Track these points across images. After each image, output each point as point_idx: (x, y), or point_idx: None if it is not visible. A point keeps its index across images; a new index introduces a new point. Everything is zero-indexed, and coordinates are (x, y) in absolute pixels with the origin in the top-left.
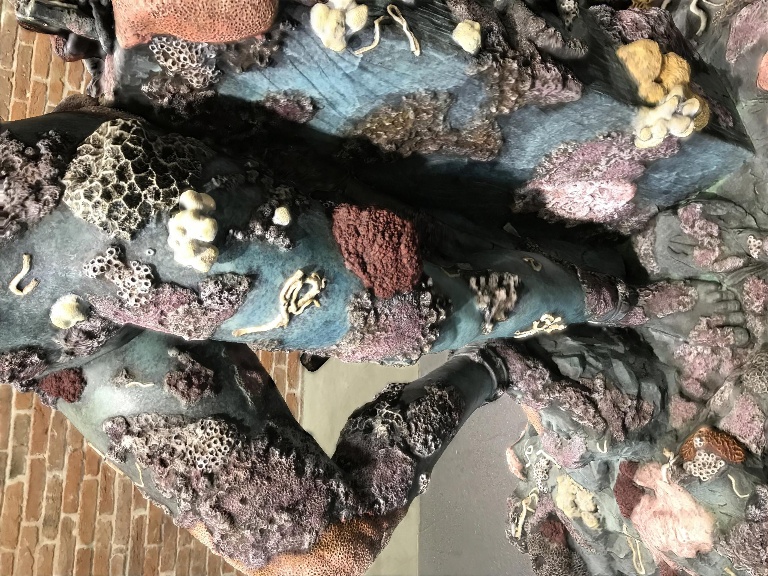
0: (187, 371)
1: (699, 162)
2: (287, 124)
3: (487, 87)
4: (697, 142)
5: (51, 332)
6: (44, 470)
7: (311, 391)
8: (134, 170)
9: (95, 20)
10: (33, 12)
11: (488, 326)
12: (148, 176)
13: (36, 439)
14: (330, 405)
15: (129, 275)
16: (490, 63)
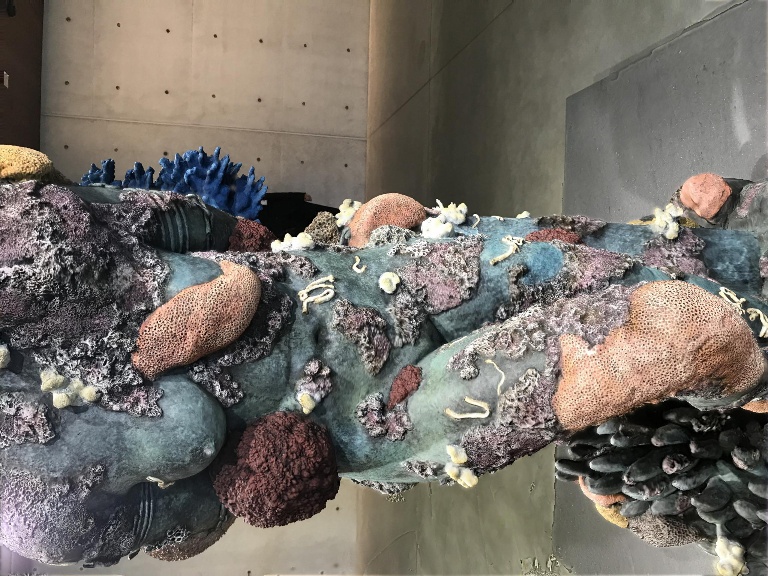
0: None
1: (730, 248)
2: None
3: (551, 227)
4: (707, 233)
5: (383, 304)
6: None
7: None
8: None
9: None
10: None
11: (672, 274)
12: None
13: None
14: None
15: None
16: None
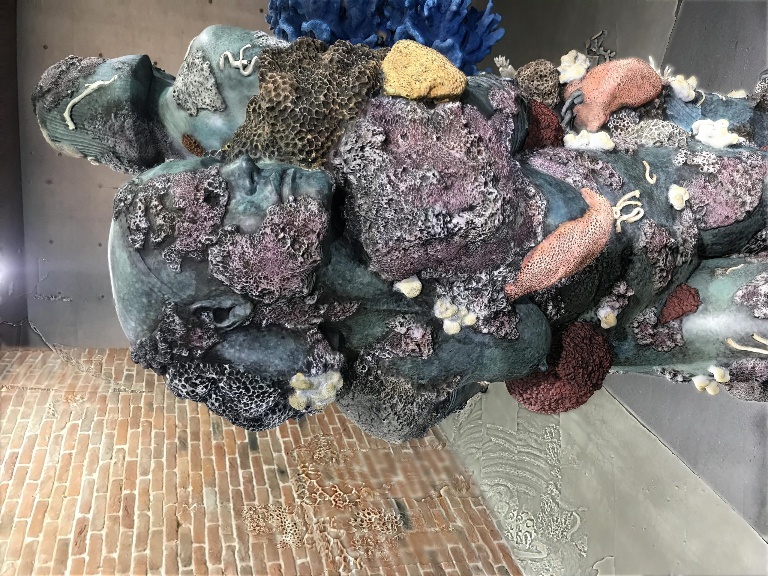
0: None
1: None
2: None
3: (766, 112)
4: None
5: (671, 221)
6: None
7: None
8: None
9: None
10: None
11: None
12: None
13: None
14: None
15: None
16: (759, 99)
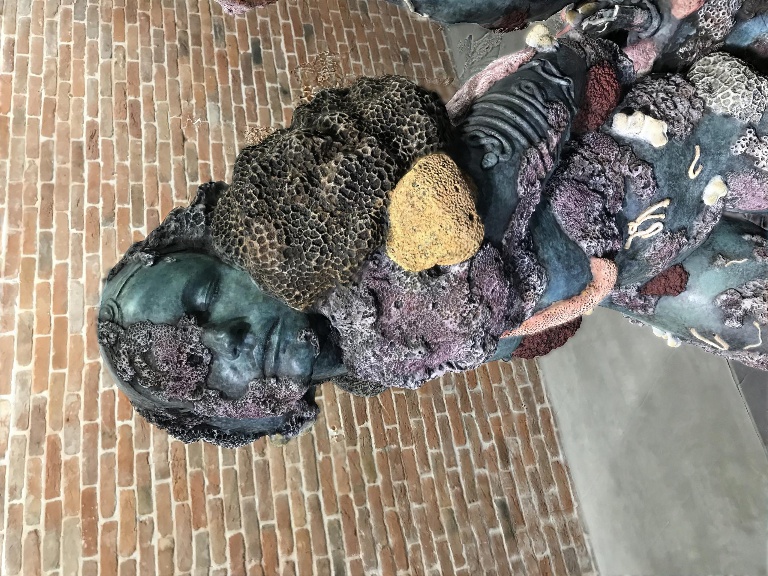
0: (765, 246)
1: None
2: (763, 60)
3: None
4: None
5: (694, 215)
6: (362, 571)
7: (575, 454)
8: (752, 72)
9: (651, 10)
10: (619, 13)
11: None
12: (758, 76)
13: (348, 542)
14: (605, 459)
15: (764, 146)
16: None
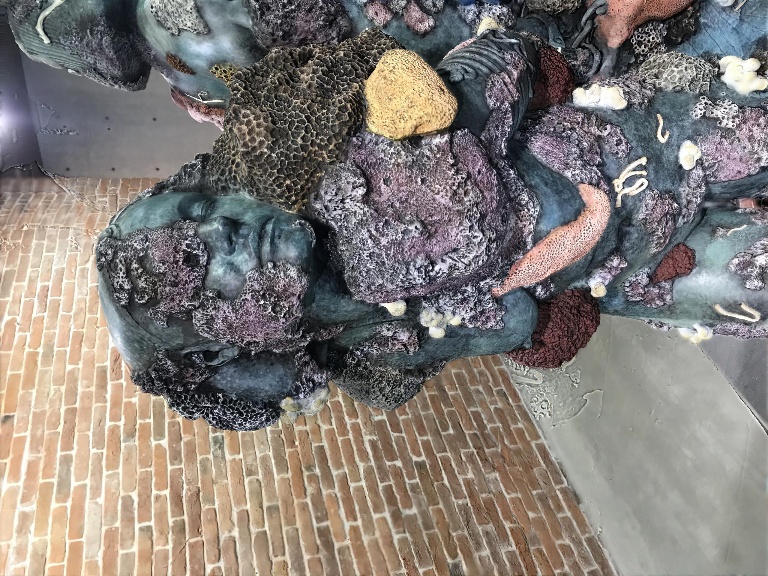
0: None
1: None
2: None
3: None
4: None
5: (678, 182)
6: None
7: None
8: None
9: (590, 49)
10: (562, 52)
11: None
12: None
13: None
14: None
15: (721, 108)
16: None
